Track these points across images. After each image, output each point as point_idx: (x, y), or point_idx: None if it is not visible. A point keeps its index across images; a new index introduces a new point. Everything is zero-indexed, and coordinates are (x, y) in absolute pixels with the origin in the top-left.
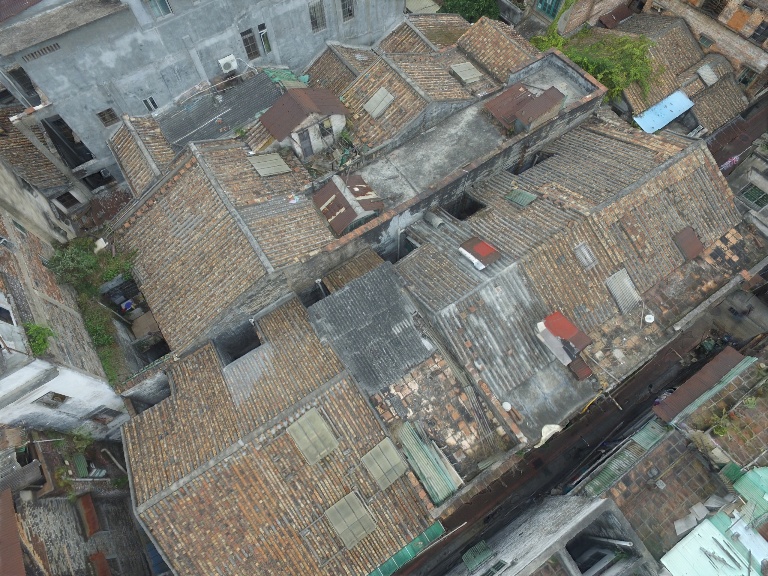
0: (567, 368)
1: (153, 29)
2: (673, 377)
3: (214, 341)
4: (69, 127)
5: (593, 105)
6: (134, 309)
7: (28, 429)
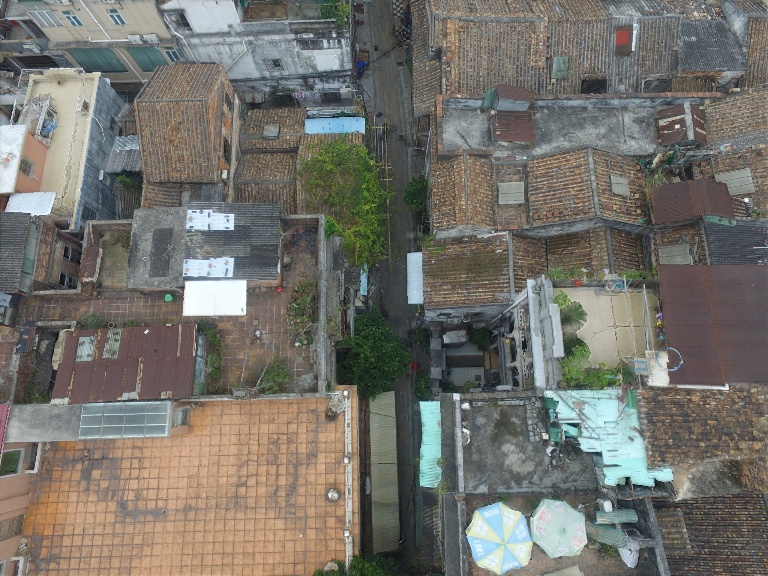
0: None
1: None
2: None
3: None
4: None
5: None
6: None
7: None
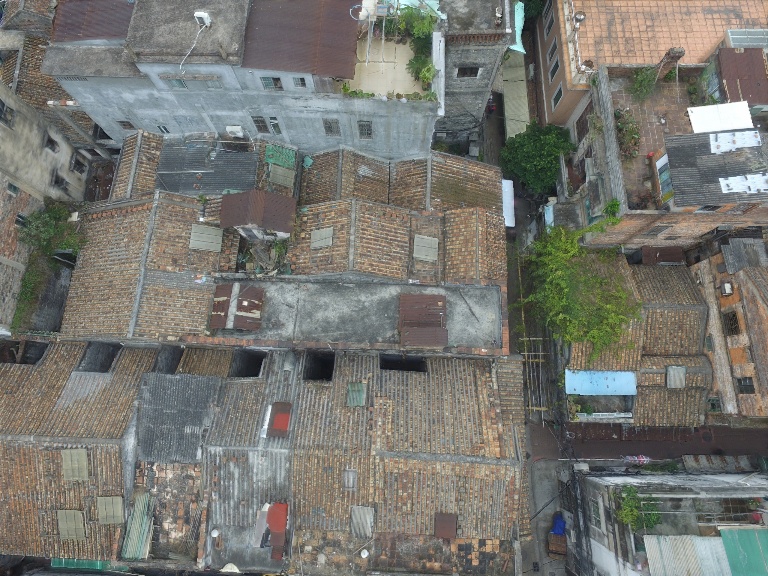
0: None
1: (169, 93)
2: None
3: (91, 342)
4: (94, 120)
5: None
6: None
7: None
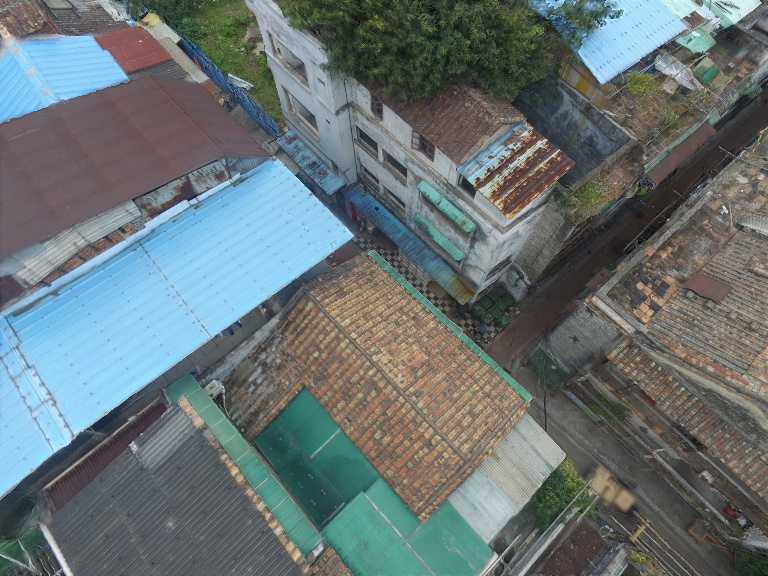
0: None
1: None
2: (527, 296)
3: None
4: None
5: None
6: None
7: None
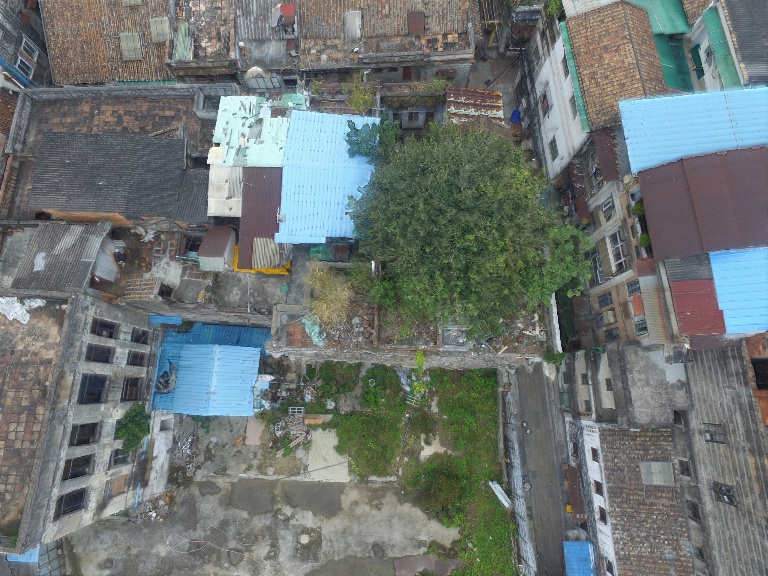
0: None
1: None
2: None
3: None
4: None
5: None
6: None
7: None
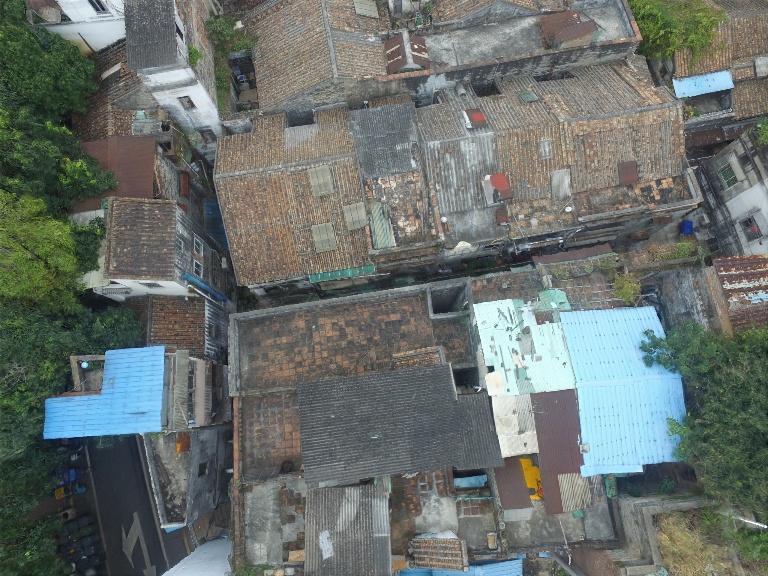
0: (495, 215)
1: None
2: None
3: (287, 114)
4: None
5: (626, 49)
6: (244, 82)
7: (169, 116)
